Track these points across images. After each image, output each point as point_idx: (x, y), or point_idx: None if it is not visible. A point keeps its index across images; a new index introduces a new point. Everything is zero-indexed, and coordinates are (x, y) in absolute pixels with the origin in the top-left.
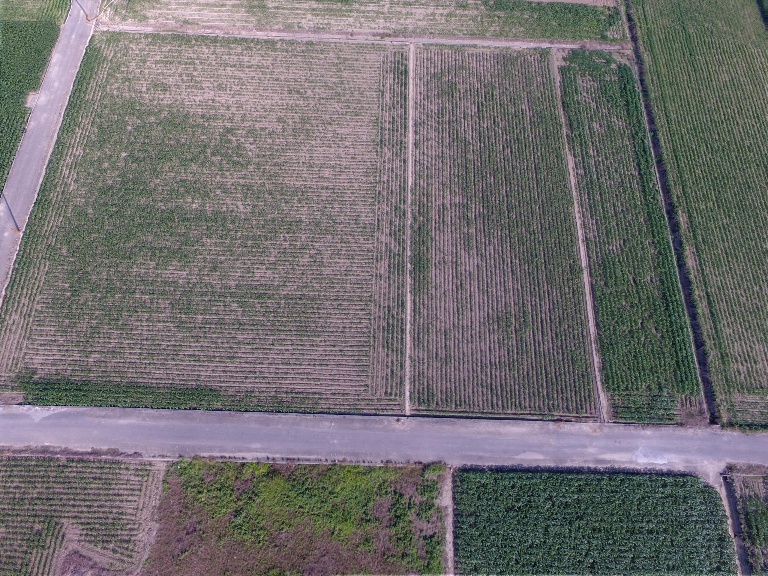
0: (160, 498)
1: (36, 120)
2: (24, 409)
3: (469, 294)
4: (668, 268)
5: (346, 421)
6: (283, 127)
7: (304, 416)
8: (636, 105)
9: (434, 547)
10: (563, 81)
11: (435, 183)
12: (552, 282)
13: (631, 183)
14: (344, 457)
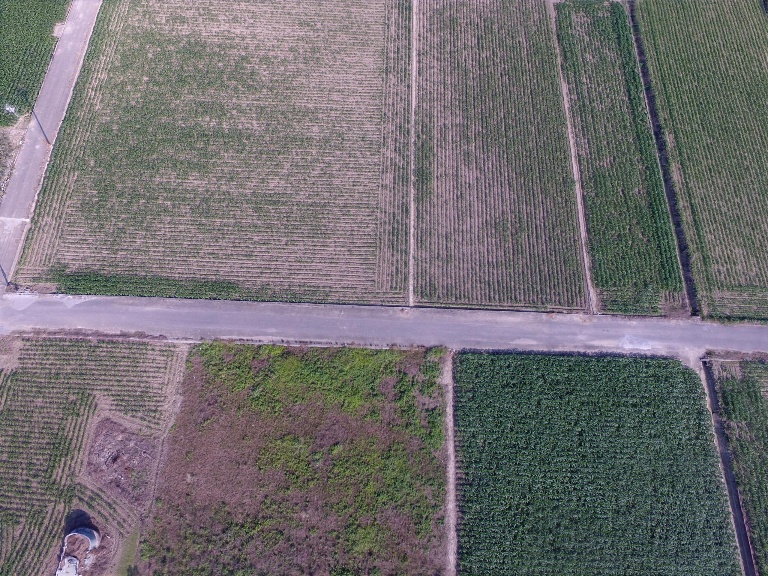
0: (184, 375)
1: (63, 47)
2: (58, 297)
3: (469, 203)
4: (655, 181)
5: (354, 310)
6: (294, 56)
7: (316, 306)
8: (627, 38)
9: (435, 418)
10: (558, 17)
11: (437, 106)
12: (546, 193)
13: (621, 107)
14: (353, 341)
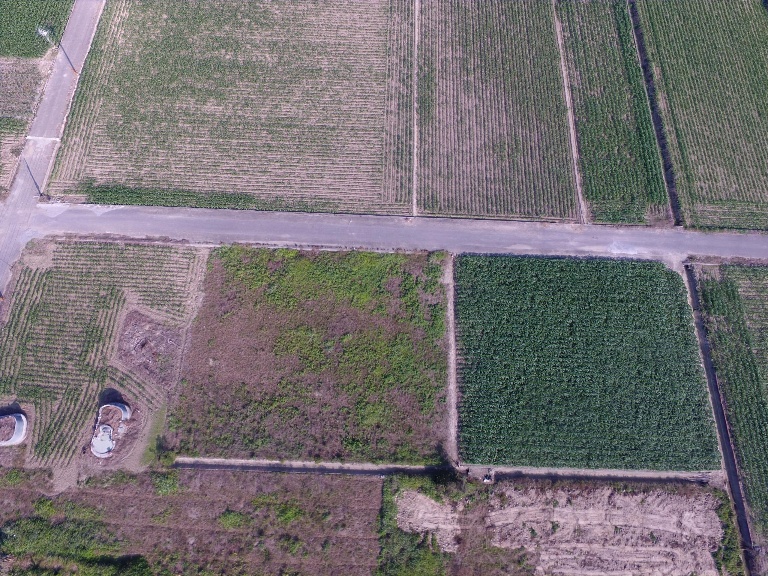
0: (205, 274)
1: None
2: (87, 206)
3: (468, 127)
4: (642, 108)
5: (362, 219)
6: None
7: (326, 215)
8: None
9: (438, 311)
10: None
11: (439, 42)
12: (541, 118)
13: (611, 43)
14: (361, 245)
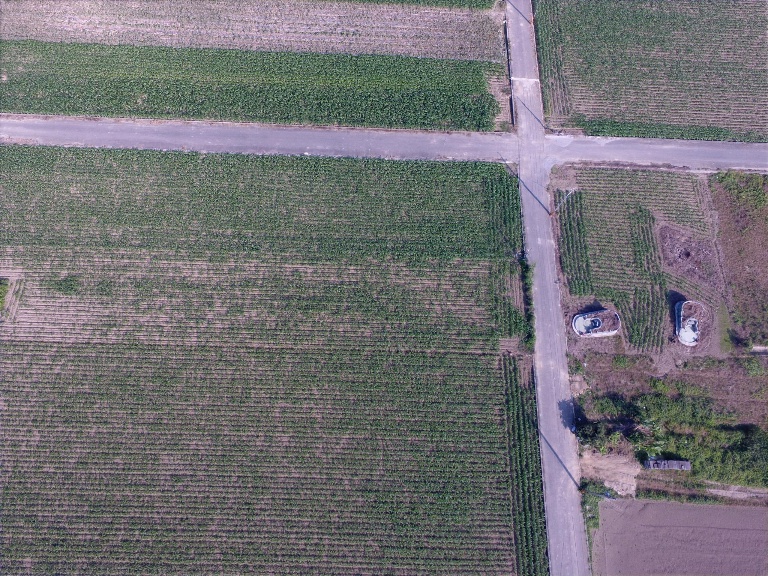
0: (711, 196)
1: None
2: (589, 138)
3: None
4: None
5: None
6: None
7: None
8: None
9: None
10: None
11: None
12: None
13: None
14: None
